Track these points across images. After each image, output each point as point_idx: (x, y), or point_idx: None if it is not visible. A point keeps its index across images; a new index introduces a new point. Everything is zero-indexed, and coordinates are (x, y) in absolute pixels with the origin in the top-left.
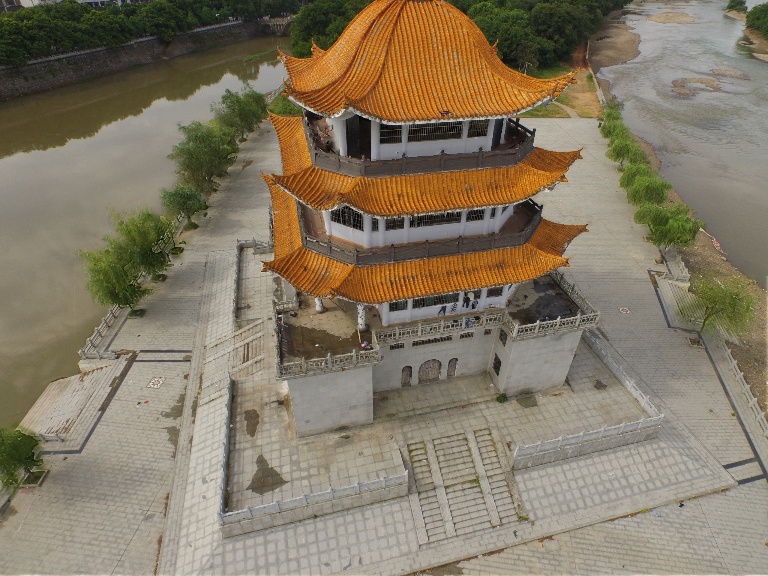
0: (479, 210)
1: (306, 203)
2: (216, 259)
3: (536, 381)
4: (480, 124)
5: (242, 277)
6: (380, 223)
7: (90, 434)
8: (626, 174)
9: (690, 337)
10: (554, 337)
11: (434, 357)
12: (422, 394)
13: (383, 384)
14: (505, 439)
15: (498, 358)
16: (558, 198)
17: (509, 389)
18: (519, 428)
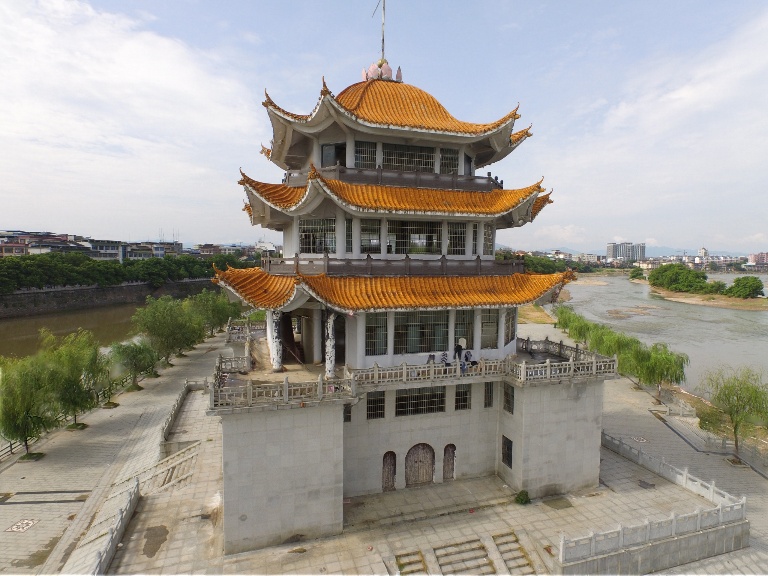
0: (459, 243)
1: (275, 205)
2: (156, 410)
3: (562, 472)
4: (450, 162)
5: (183, 410)
6: (354, 243)
7: None
8: (593, 339)
9: (727, 458)
10: (571, 395)
11: (424, 439)
12: (412, 497)
13: (357, 483)
14: (540, 543)
15: (507, 440)
16: None
17: (529, 483)
18: (556, 530)
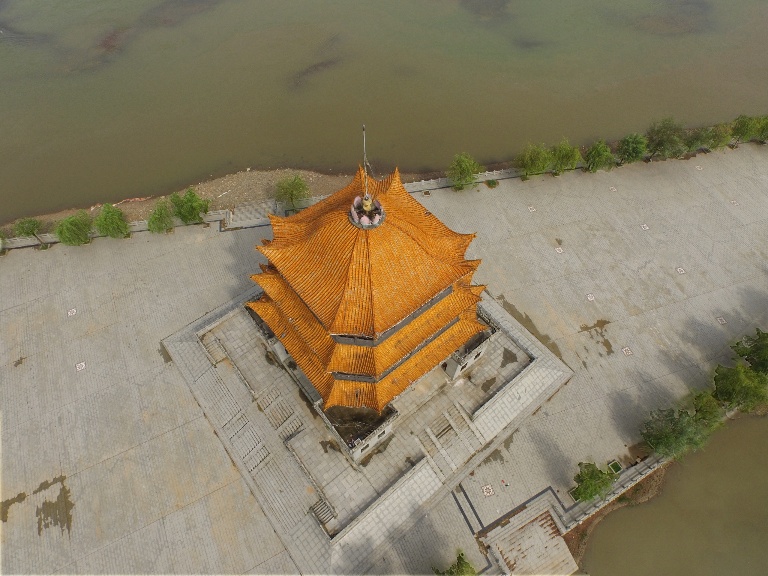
0: None
1: None
2: None
3: None
4: None
5: (376, 496)
6: None
7: (540, 494)
8: (72, 236)
9: None
10: None
11: None
12: None
13: None
14: None
15: None
16: (92, 299)
17: None
18: None
